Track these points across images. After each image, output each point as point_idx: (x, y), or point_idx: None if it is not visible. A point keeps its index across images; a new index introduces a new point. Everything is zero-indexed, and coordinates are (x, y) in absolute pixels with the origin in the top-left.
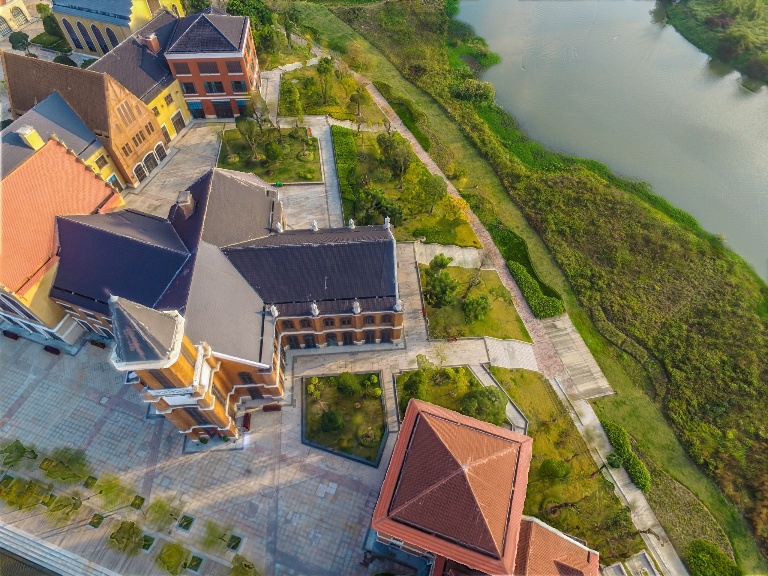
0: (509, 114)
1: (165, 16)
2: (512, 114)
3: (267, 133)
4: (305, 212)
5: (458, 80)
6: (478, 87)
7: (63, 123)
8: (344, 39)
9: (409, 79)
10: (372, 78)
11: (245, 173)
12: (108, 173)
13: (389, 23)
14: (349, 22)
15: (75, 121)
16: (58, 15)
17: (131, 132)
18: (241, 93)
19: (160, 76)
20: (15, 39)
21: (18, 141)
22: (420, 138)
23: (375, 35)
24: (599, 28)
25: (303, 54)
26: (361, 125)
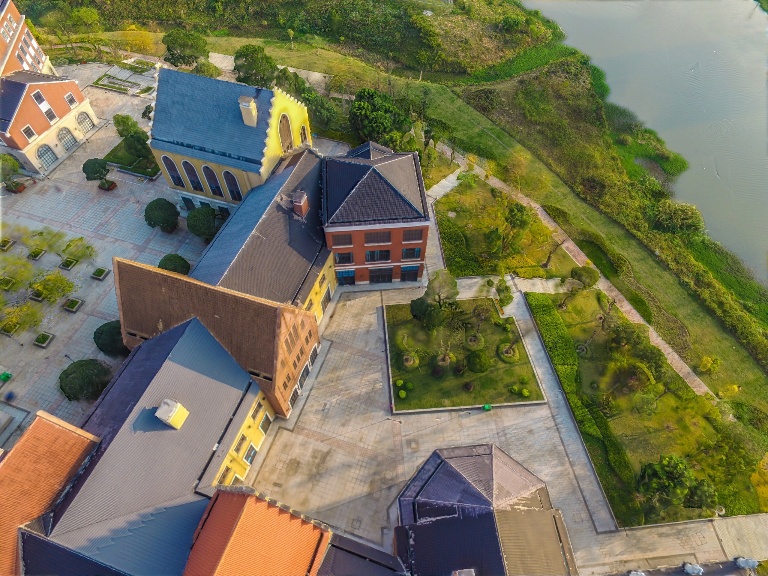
0: (731, 253)
1: (308, 157)
2: (735, 253)
3: (450, 317)
4: (536, 460)
5: (648, 199)
6: (684, 215)
7: (208, 369)
8: (485, 137)
9: (586, 200)
10: (538, 199)
11: (495, 458)
12: (260, 417)
13: (534, 112)
14: (483, 111)
15: (223, 360)
16: (157, 152)
17: (292, 357)
18: (411, 259)
19: (313, 252)
20: (91, 169)
21: (154, 422)
22: (634, 301)
23: (521, 130)
24: (765, 100)
25: (443, 164)
26: (552, 282)
